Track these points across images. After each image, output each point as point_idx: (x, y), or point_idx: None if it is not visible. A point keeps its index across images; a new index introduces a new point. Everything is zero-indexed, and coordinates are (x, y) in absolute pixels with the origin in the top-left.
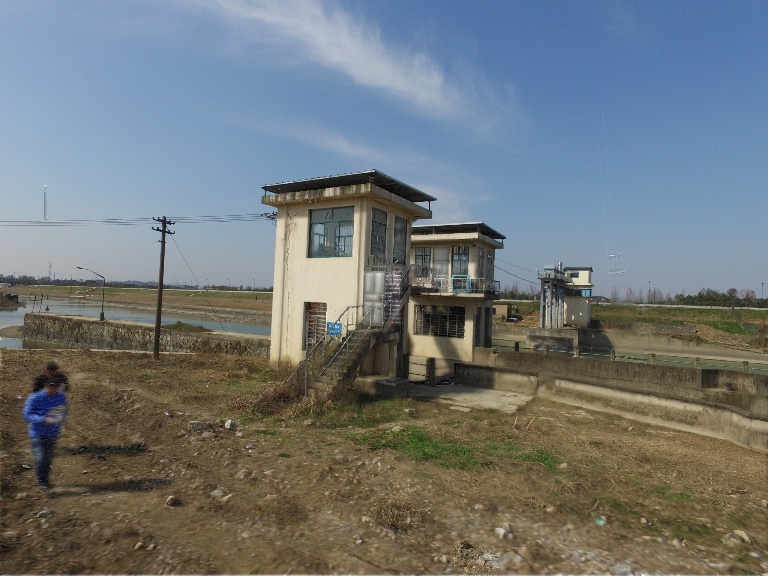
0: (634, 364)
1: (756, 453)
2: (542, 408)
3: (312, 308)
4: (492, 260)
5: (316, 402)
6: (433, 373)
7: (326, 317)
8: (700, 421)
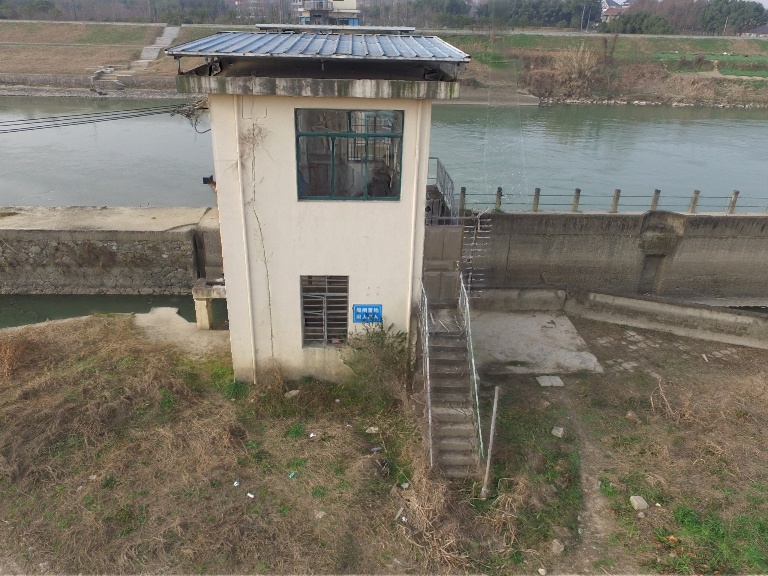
0: (583, 217)
1: None
2: (601, 341)
3: (314, 282)
4: None
5: (489, 485)
6: None
7: (350, 297)
8: (749, 332)
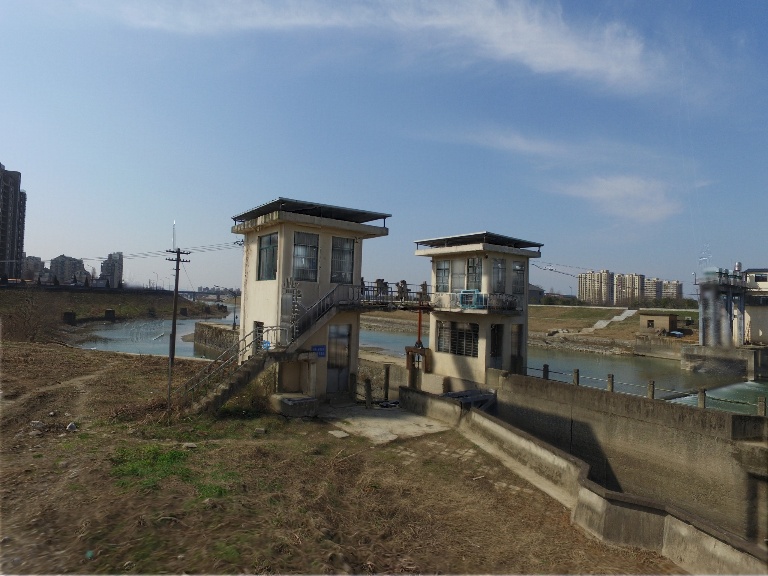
0: (647, 400)
1: (573, 531)
2: (432, 442)
3: None
4: (525, 271)
5: None
6: (368, 394)
7: (263, 336)
8: (562, 480)
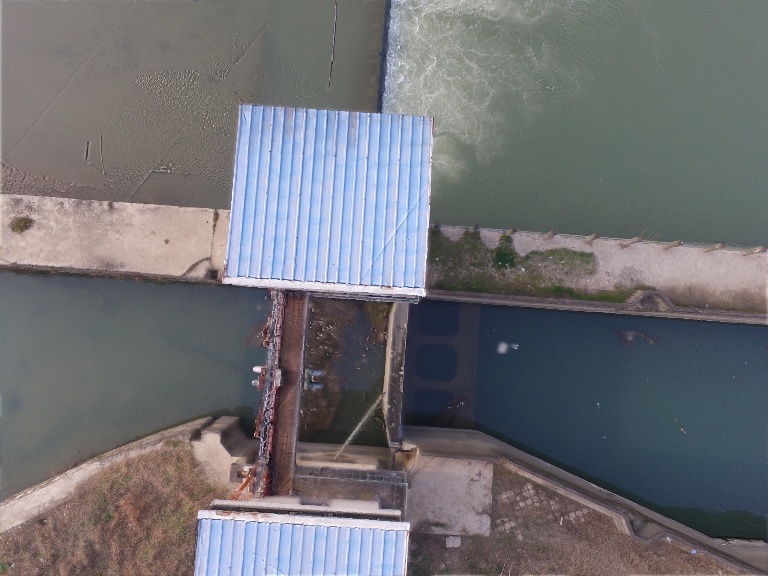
0: None
1: (622, 535)
2: (504, 496)
3: None
4: None
5: None
6: None
7: None
8: None
